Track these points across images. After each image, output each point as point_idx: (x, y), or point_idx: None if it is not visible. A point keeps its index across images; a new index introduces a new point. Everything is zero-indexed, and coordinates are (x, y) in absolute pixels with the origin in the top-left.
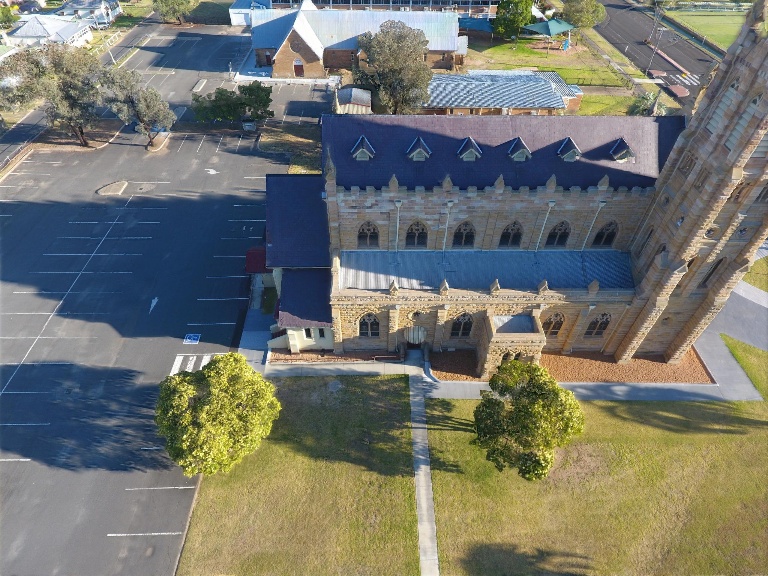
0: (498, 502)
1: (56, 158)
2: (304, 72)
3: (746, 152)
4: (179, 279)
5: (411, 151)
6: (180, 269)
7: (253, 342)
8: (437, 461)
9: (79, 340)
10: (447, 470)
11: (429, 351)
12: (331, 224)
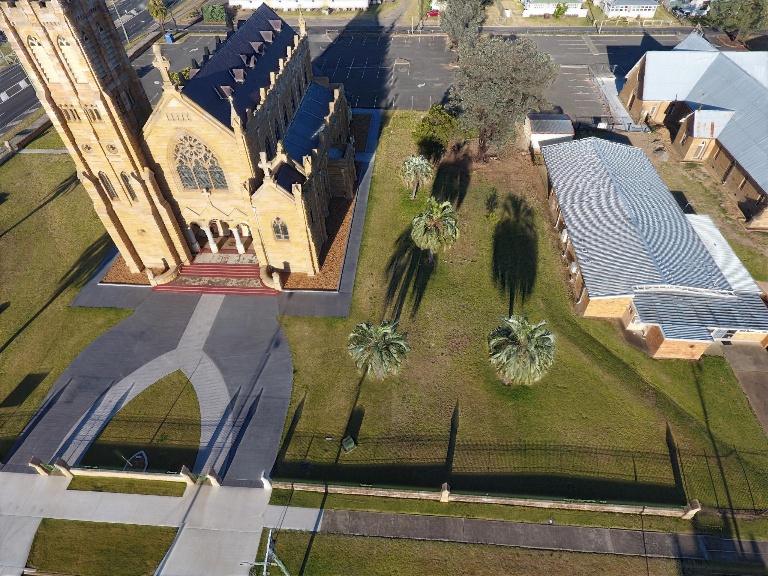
0: None
1: None
2: None
3: None
4: None
5: None
6: None
7: None
8: None
9: None
10: None
11: None
12: None
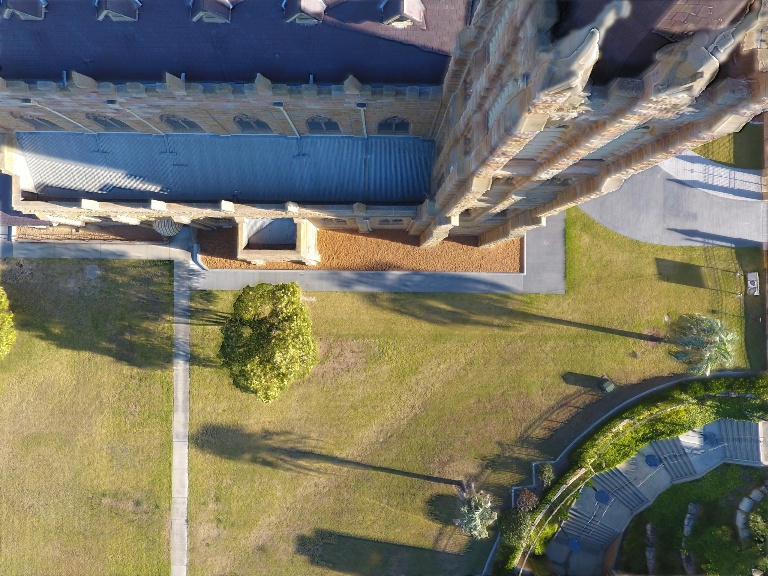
0: (250, 395)
1: None
2: None
3: (486, 170)
4: None
5: None
6: None
7: None
8: (197, 357)
9: None
10: (206, 366)
11: (200, 229)
12: None
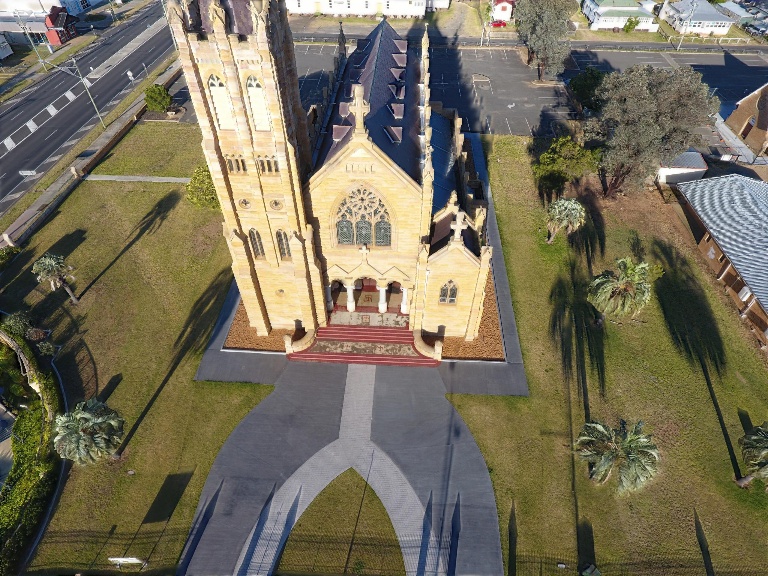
0: None
1: (511, 57)
2: (748, 134)
3: None
4: None
5: None
6: None
7: None
8: None
9: None
10: None
11: None
12: None
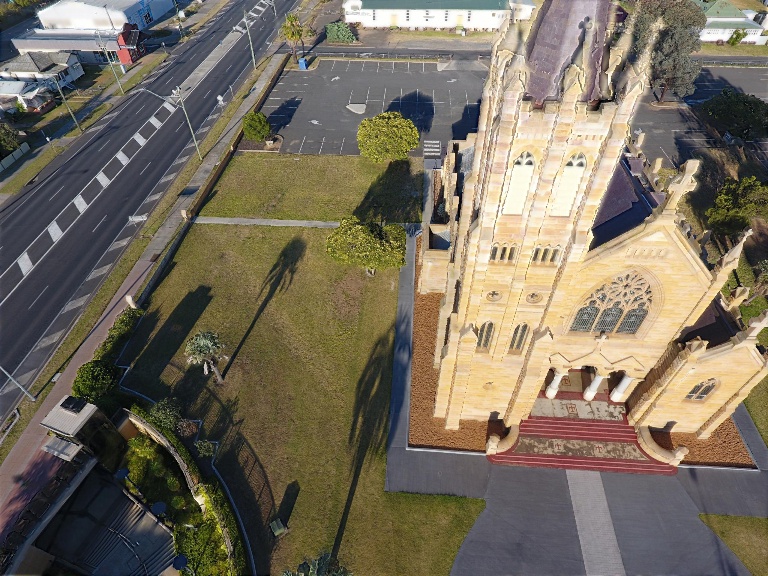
0: None
1: None
2: None
3: None
4: None
5: None
6: None
7: None
8: None
9: (449, 113)
10: None
11: None
12: None
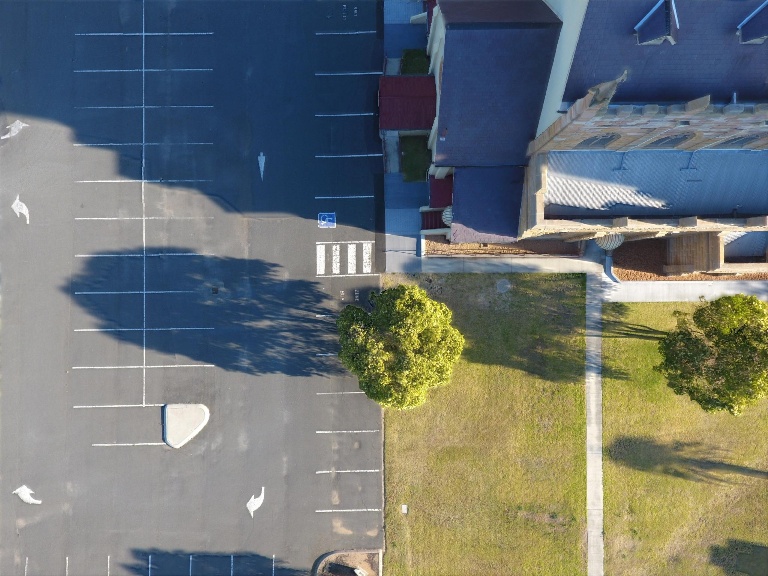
0: (661, 407)
1: None
2: None
3: None
4: (280, 120)
5: (751, 33)
6: (275, 100)
7: (401, 225)
8: (609, 370)
9: (194, 222)
10: (618, 378)
11: None
12: (556, 139)
